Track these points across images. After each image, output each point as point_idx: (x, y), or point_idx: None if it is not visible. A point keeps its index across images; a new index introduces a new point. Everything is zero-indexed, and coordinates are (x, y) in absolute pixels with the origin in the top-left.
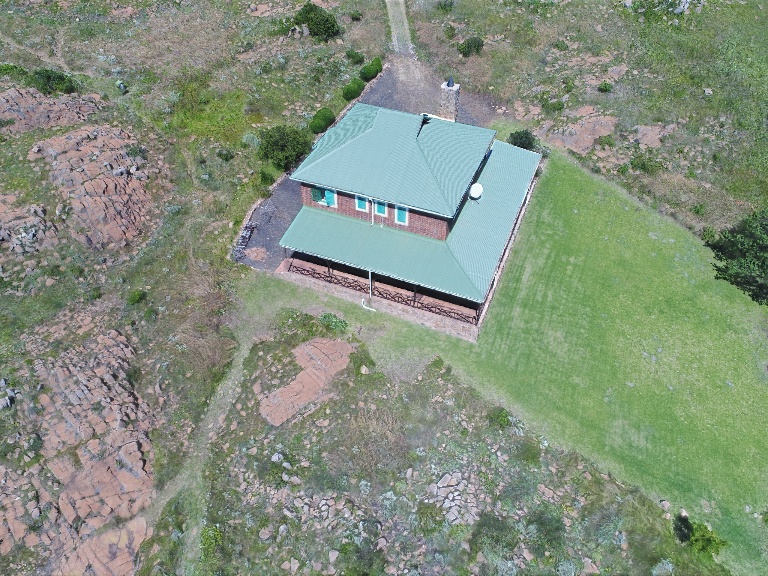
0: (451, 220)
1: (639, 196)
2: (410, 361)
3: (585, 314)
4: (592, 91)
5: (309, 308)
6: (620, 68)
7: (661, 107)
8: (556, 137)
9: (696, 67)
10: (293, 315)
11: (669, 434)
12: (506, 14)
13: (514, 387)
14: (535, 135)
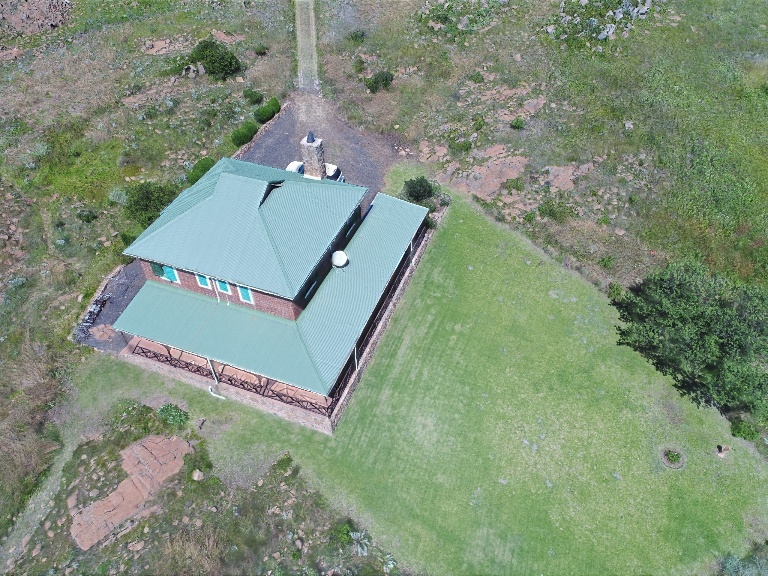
0: (301, 298)
1: (544, 248)
2: (253, 461)
3: (462, 395)
4: (504, 128)
5: (150, 398)
6: (536, 101)
7: (576, 145)
8: (460, 181)
9: (619, 97)
10: (129, 408)
11: (539, 545)
12: (420, 44)
13: (368, 491)
14: (435, 181)
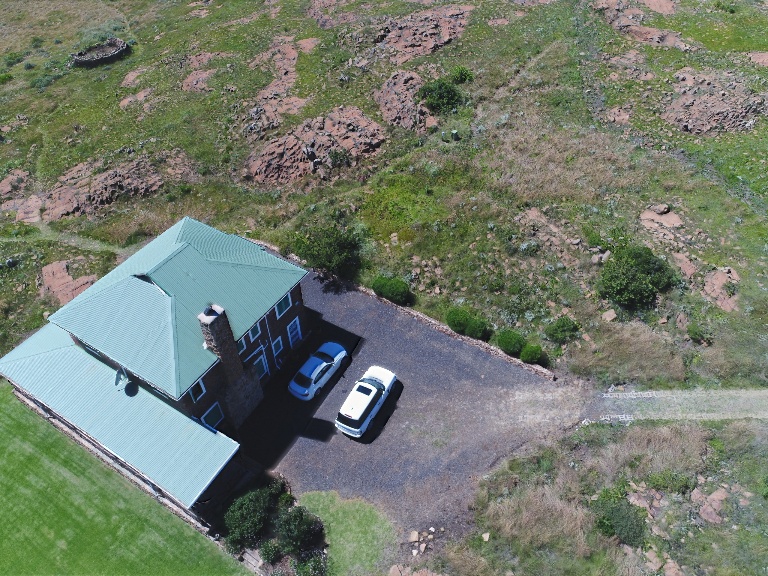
0: None
1: None
2: None
3: None
4: None
5: None
6: None
7: None
8: None
9: None
10: None
11: None
12: None
13: None
14: (319, 571)
